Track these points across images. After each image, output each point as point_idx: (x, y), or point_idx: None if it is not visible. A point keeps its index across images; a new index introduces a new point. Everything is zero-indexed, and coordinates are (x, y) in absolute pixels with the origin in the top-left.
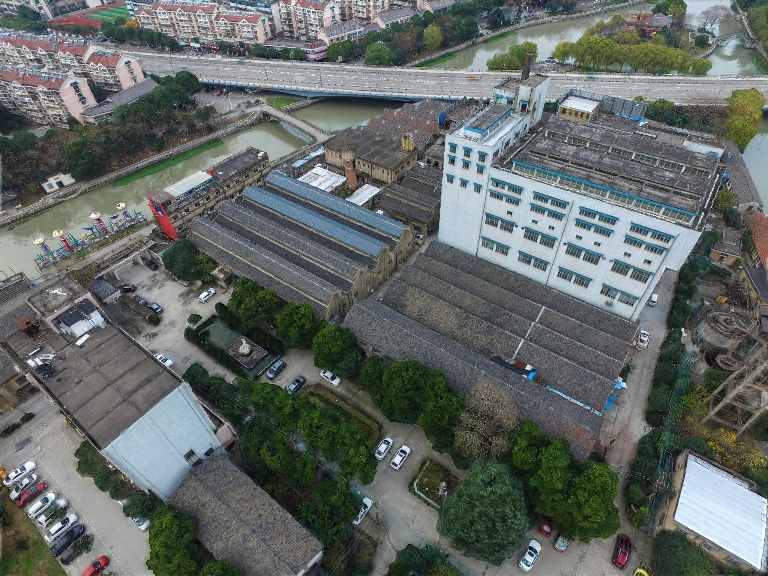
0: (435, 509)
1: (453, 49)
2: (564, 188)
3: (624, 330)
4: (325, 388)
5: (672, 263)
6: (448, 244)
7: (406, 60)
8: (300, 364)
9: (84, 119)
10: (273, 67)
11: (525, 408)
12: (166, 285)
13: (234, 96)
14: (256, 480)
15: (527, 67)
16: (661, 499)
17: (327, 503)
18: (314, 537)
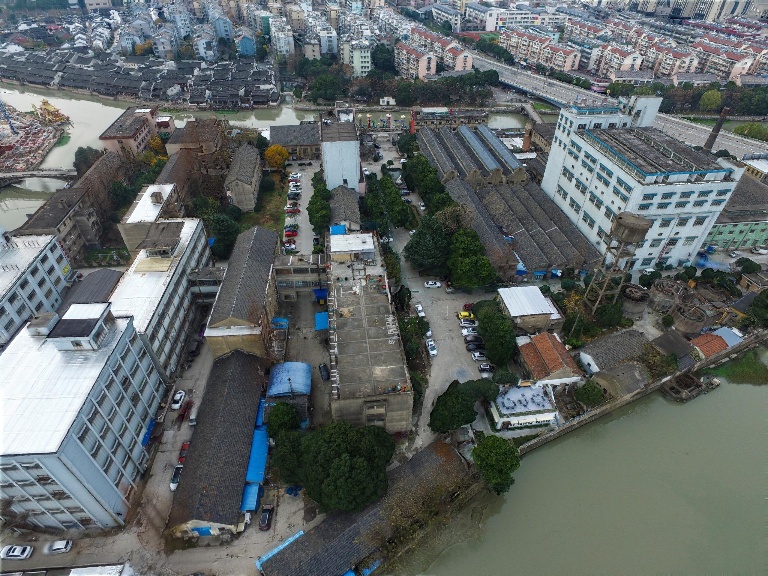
0: None
1: (732, 117)
2: (599, 151)
3: (591, 256)
4: (416, 208)
5: (629, 210)
6: (544, 190)
7: (671, 111)
8: (416, 198)
9: (423, 80)
10: (558, 86)
11: (484, 237)
12: (393, 152)
13: (517, 96)
14: (360, 211)
15: (721, 118)
16: None
17: None
18: None
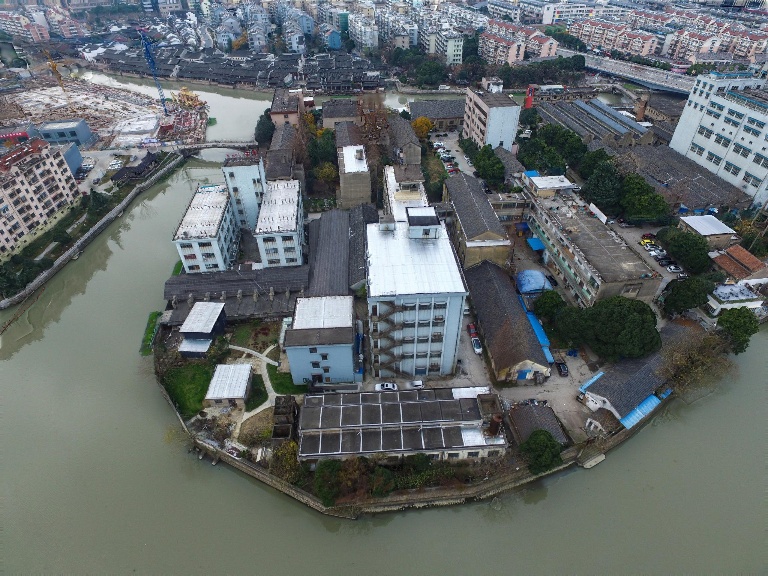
0: None
1: None
2: None
3: (742, 197)
4: None
5: None
6: None
7: None
8: None
9: (512, 66)
10: (640, 69)
11: (646, 182)
12: None
13: (602, 78)
14: None
15: None
16: None
17: None
18: None
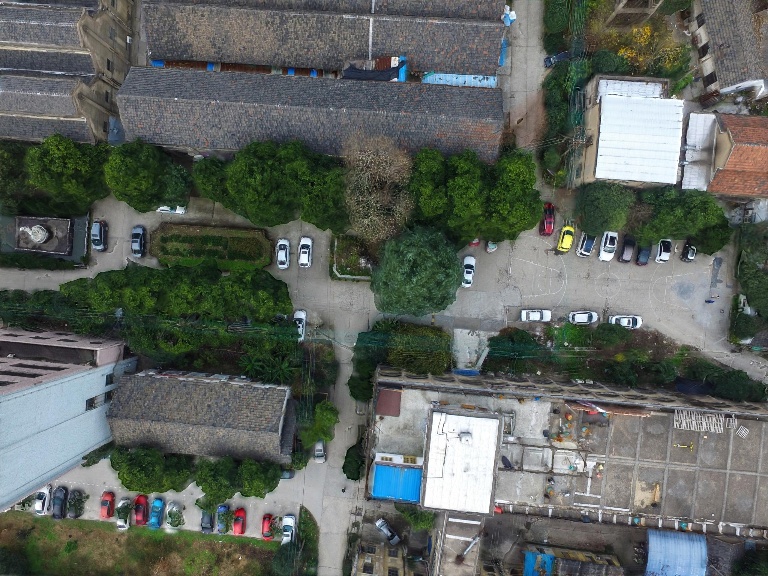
0: (366, 281)
1: None
2: None
3: None
4: (174, 224)
5: None
6: None
7: None
8: (122, 210)
9: None
10: None
11: (412, 132)
12: None
13: None
14: (180, 363)
15: None
16: (577, 153)
17: (263, 350)
18: (272, 380)
